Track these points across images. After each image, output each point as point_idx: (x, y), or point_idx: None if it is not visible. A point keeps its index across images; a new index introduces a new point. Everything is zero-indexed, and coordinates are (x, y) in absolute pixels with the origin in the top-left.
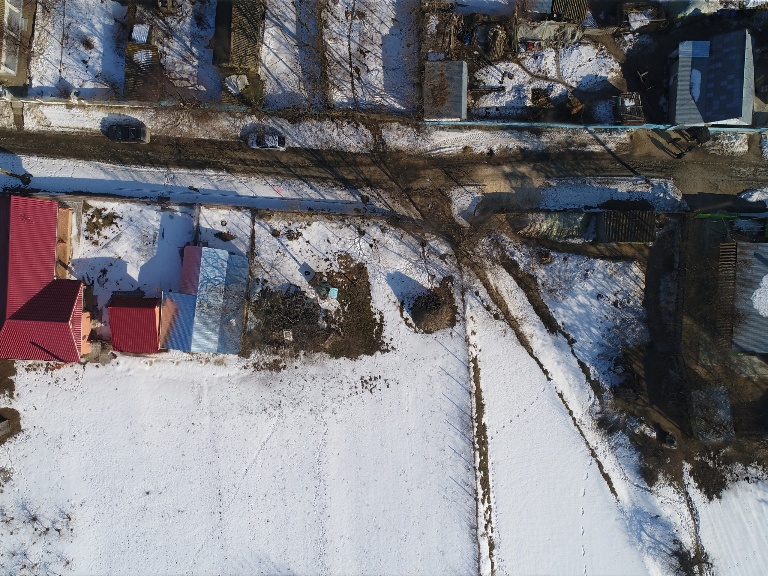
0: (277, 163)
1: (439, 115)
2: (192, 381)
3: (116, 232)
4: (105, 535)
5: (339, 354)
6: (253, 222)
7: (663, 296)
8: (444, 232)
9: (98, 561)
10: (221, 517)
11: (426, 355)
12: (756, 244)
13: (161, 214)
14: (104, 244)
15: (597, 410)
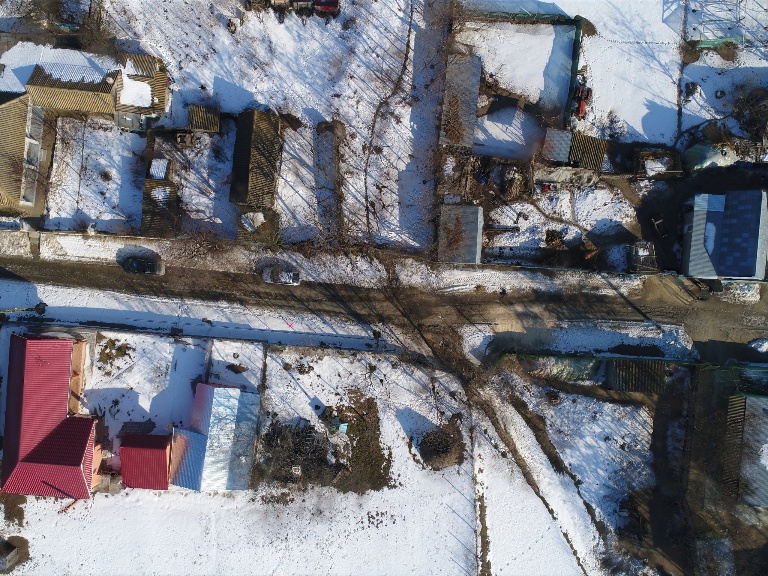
0: (290, 296)
1: (453, 259)
2: (200, 513)
3: (129, 363)
4: None
5: (347, 489)
6: (265, 355)
7: (670, 441)
8: (454, 369)
9: None
10: None
11: (433, 492)
12: (765, 400)
13: (174, 346)
14: (117, 375)
15: (601, 550)
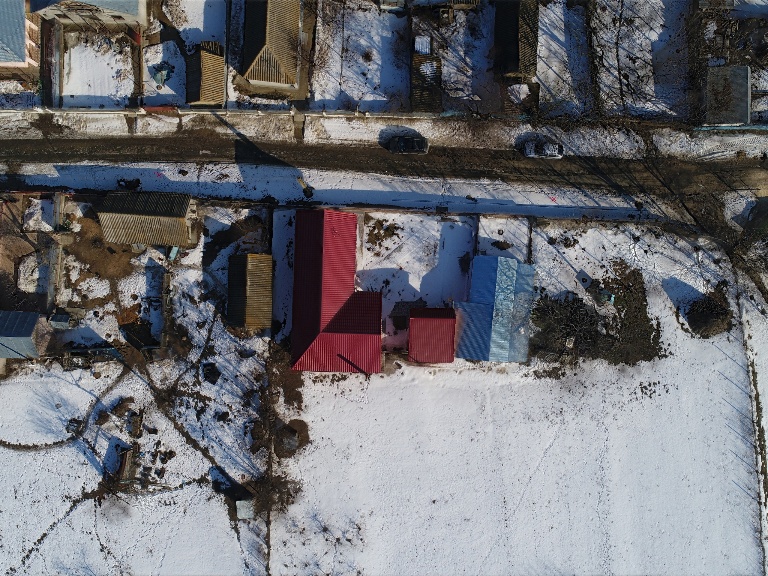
0: (551, 171)
1: (723, 120)
2: (475, 390)
3: (397, 243)
4: (393, 544)
5: (618, 360)
6: (530, 230)
7: None
8: (718, 237)
9: (387, 570)
10: (507, 524)
11: (704, 360)
12: None
13: (442, 224)
14: (386, 255)
15: None
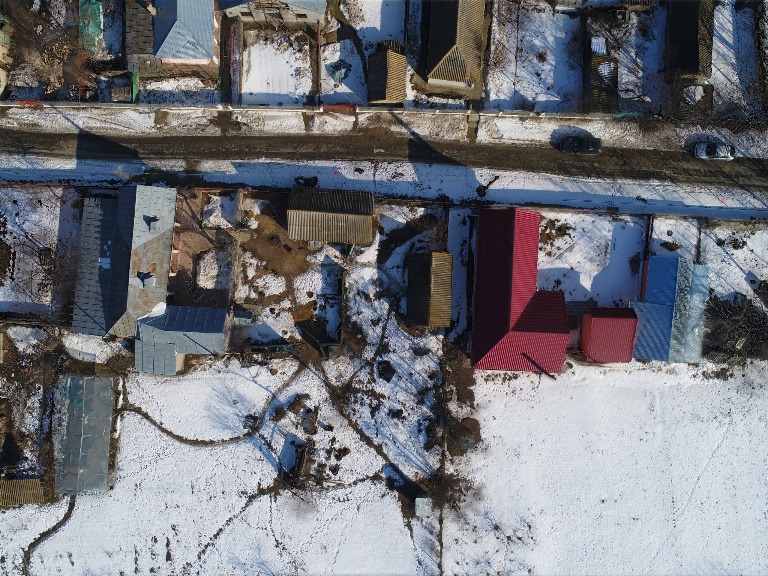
0: (720, 173)
1: None
2: (644, 390)
3: (569, 243)
4: (563, 543)
5: None
6: (700, 232)
7: None
8: None
9: (557, 569)
10: (675, 524)
11: None
12: None
13: (613, 225)
14: (557, 255)
15: None
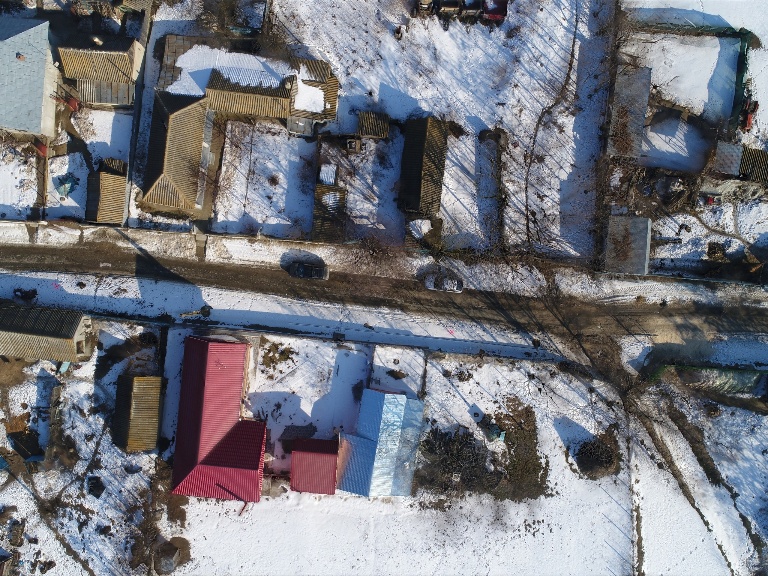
0: (451, 304)
1: (621, 270)
2: (359, 517)
3: (291, 367)
4: None
5: (504, 496)
6: (426, 362)
7: None
8: (613, 379)
9: None
10: None
11: (590, 501)
12: None
13: (337, 351)
14: (279, 378)
15: (755, 563)
